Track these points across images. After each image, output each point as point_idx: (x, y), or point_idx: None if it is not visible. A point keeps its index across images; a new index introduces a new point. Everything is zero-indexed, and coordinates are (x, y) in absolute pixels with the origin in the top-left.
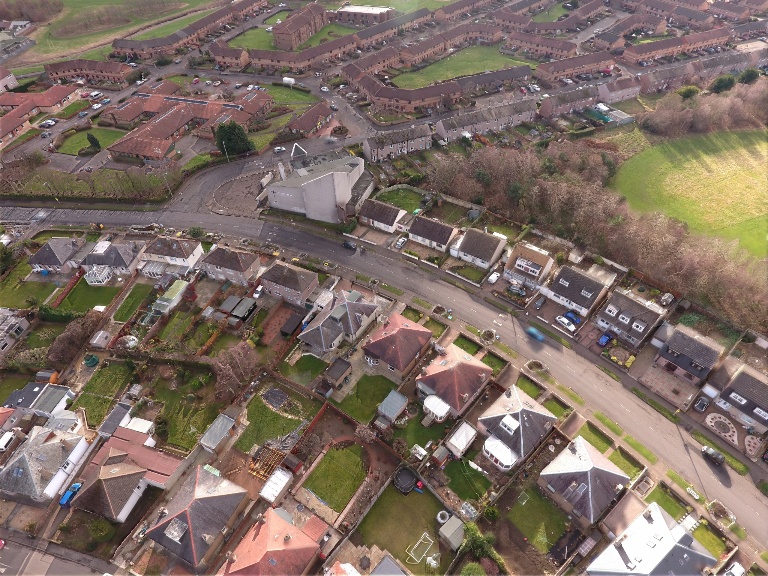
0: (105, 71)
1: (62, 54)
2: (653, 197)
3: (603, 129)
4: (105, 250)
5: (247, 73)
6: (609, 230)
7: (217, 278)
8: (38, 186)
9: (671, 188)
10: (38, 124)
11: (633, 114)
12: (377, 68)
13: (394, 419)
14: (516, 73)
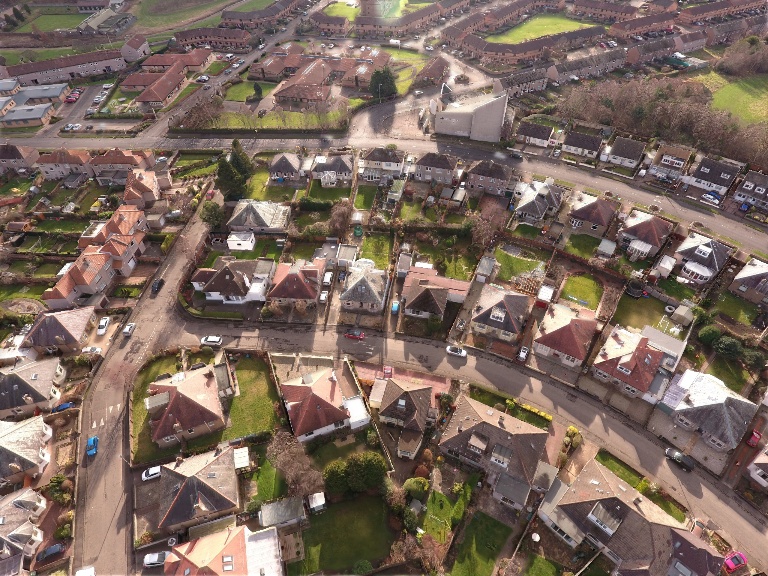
0: (229, 37)
1: (168, 27)
2: (744, 118)
3: (685, 72)
4: (326, 161)
5: (352, 38)
6: (729, 134)
7: (423, 179)
8: (228, 124)
9: (757, 112)
10: (194, 80)
11: (707, 60)
12: (469, 31)
13: (610, 257)
14: (594, 32)
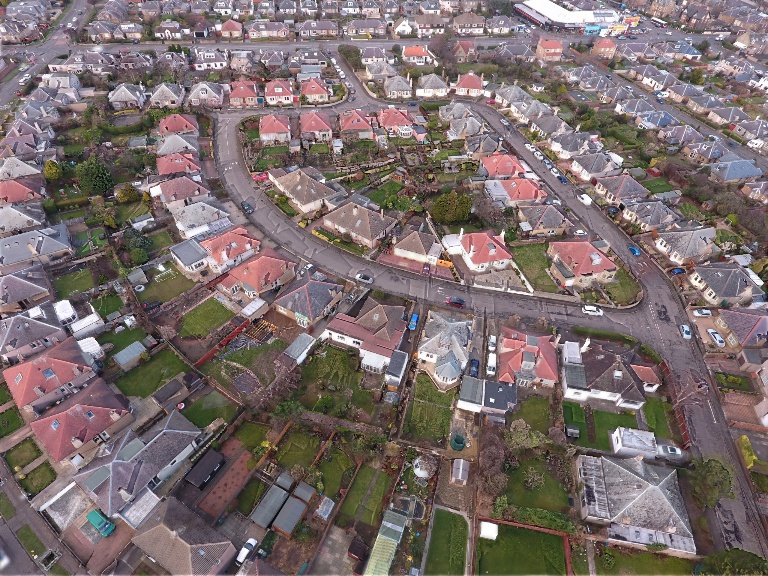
0: None
1: None
2: None
3: None
4: None
5: None
6: None
7: None
8: None
9: None
10: None
11: None
12: None
13: None
14: None
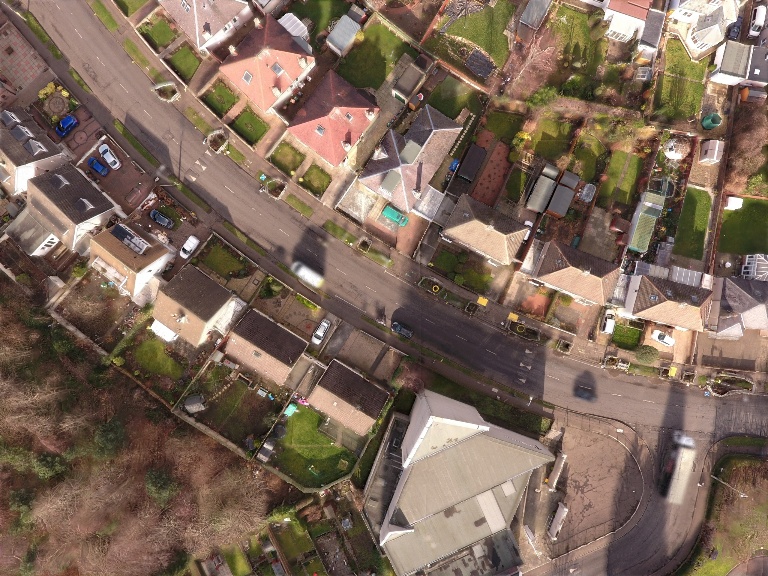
0: None
1: None
2: None
3: None
4: None
5: None
6: None
7: None
8: None
9: None
10: None
11: None
12: None
13: None
14: None
